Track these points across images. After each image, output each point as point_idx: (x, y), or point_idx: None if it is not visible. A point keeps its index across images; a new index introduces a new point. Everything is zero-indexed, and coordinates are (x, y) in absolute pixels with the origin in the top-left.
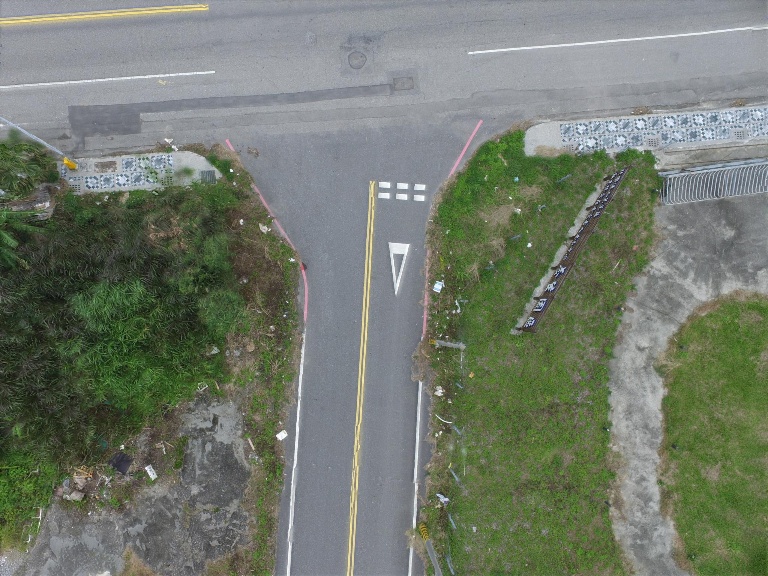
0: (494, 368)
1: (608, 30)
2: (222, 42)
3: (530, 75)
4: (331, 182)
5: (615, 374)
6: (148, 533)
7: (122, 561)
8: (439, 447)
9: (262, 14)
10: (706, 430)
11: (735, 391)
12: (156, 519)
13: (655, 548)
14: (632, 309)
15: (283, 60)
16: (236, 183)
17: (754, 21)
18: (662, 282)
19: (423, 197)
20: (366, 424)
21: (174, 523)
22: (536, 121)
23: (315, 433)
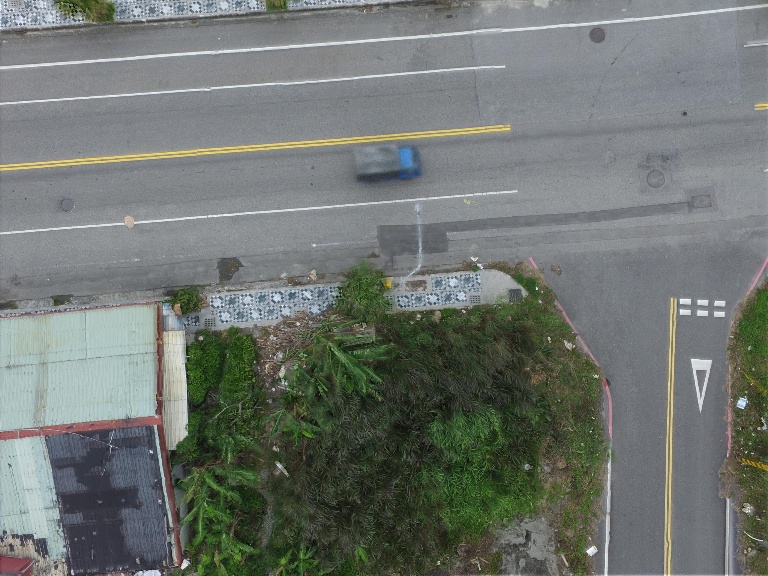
0: None
1: None
2: (524, 162)
3: None
4: (633, 299)
5: None
6: None
7: None
8: (748, 564)
9: (562, 134)
10: None
11: None
12: None
13: None
14: None
15: (583, 179)
16: (542, 301)
17: None
18: None
19: (723, 313)
20: (676, 541)
21: None
22: None
23: (625, 549)
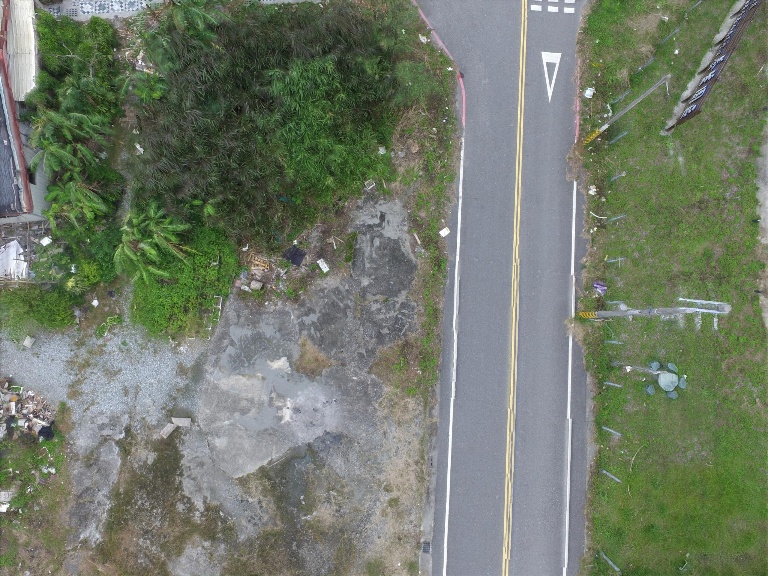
0: (645, 167)
1: None
2: None
3: None
4: None
5: (762, 171)
6: (322, 322)
7: (298, 347)
8: (594, 242)
9: None
10: None
11: None
12: (329, 309)
13: None
14: None
15: None
16: None
17: None
18: None
19: (573, 9)
20: (525, 221)
21: (346, 313)
22: None
23: (476, 230)
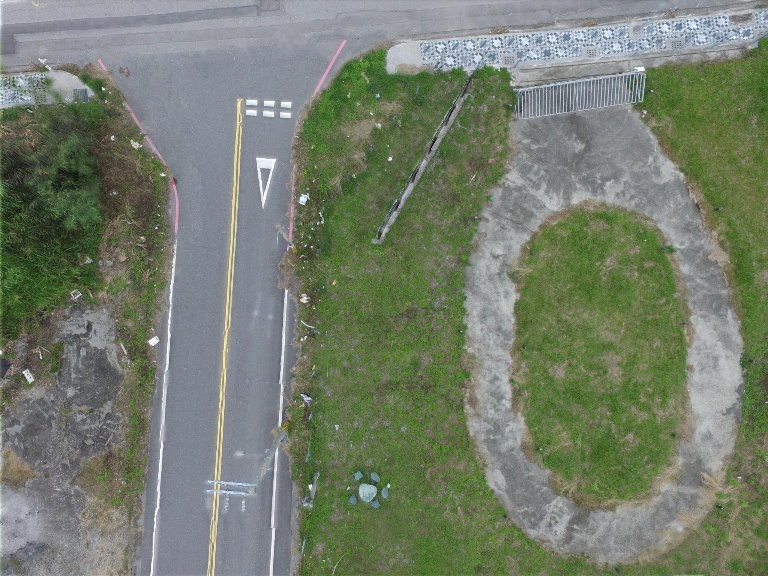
0: (356, 276)
1: None
2: None
3: None
4: (200, 100)
5: (471, 280)
6: (26, 433)
7: (1, 459)
8: (304, 351)
9: None
10: (554, 331)
11: (582, 294)
12: (33, 420)
13: (507, 443)
14: (487, 219)
15: None
16: (108, 101)
17: None
18: (516, 193)
19: (289, 114)
20: (234, 330)
21: (51, 423)
22: (398, 41)
23: (186, 339)
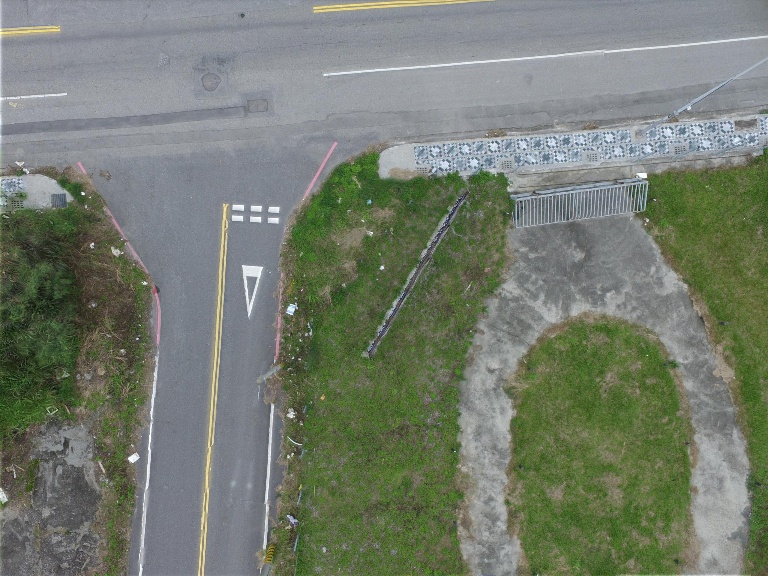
0: (346, 390)
1: (463, 52)
2: (74, 64)
3: (385, 97)
4: (184, 205)
5: (465, 395)
6: None
7: None
8: (291, 469)
9: (114, 35)
10: (552, 451)
11: (581, 412)
12: (6, 542)
13: (502, 566)
14: (483, 331)
15: (136, 82)
16: (88, 206)
17: (607, 43)
18: (513, 304)
19: (277, 220)
20: (218, 446)
21: (24, 546)
22: (391, 143)
23: (167, 455)
